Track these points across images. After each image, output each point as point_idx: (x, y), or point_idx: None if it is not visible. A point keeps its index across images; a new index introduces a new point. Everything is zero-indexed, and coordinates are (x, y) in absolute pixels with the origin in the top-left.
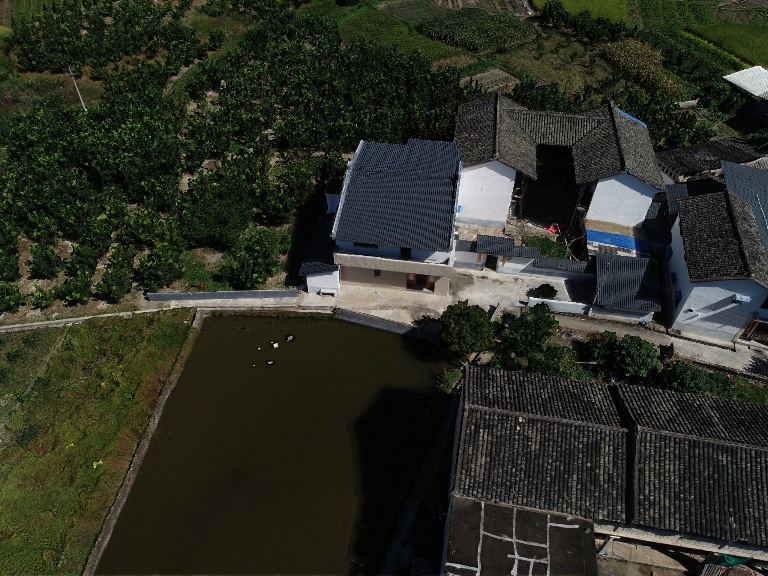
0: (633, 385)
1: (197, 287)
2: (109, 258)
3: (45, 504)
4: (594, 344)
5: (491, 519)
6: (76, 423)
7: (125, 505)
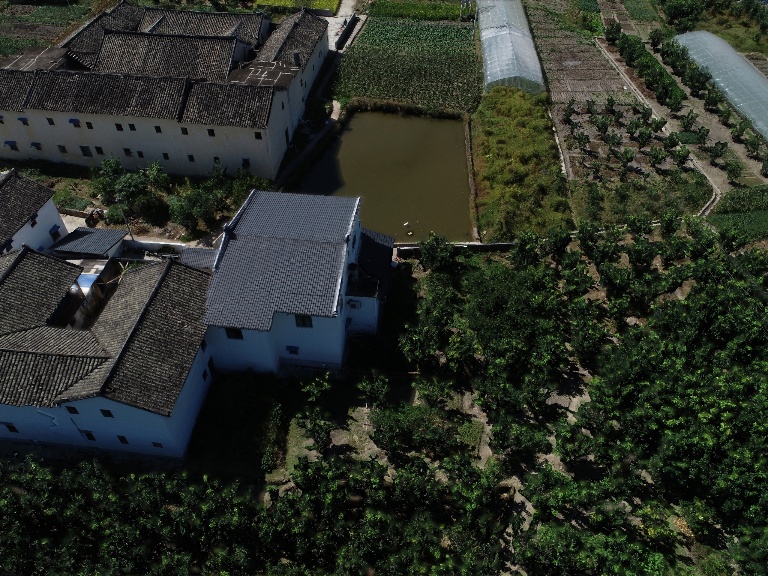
0: (166, 118)
1: (491, 259)
2: (599, 291)
3: None
4: (156, 200)
5: (271, 83)
6: None
7: None
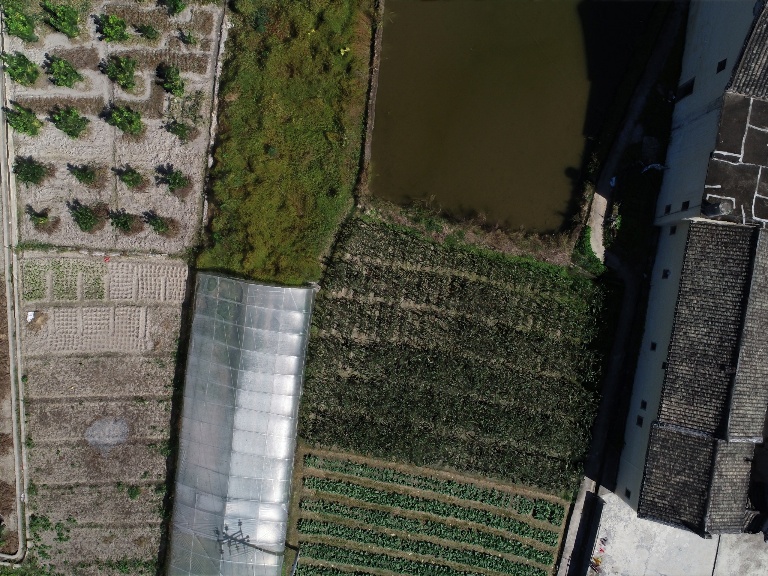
0: None
1: None
2: None
3: (308, 91)
4: None
5: (757, 114)
6: (311, 7)
7: (377, 90)
